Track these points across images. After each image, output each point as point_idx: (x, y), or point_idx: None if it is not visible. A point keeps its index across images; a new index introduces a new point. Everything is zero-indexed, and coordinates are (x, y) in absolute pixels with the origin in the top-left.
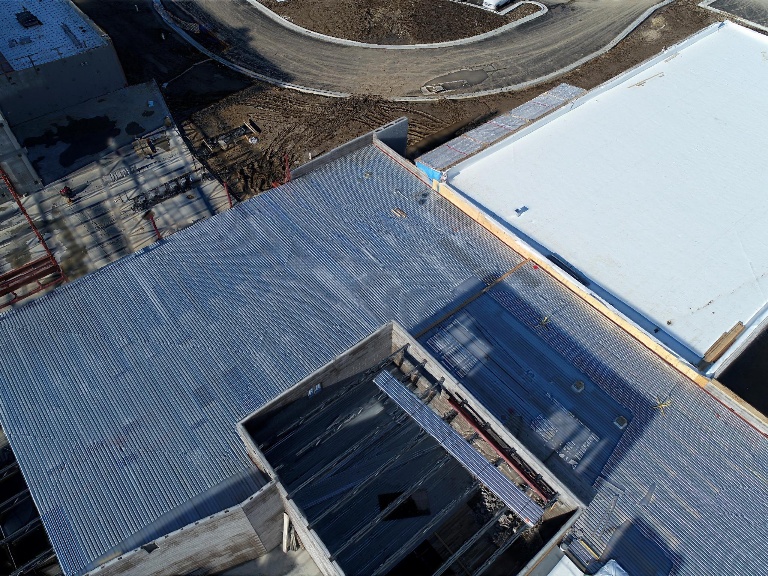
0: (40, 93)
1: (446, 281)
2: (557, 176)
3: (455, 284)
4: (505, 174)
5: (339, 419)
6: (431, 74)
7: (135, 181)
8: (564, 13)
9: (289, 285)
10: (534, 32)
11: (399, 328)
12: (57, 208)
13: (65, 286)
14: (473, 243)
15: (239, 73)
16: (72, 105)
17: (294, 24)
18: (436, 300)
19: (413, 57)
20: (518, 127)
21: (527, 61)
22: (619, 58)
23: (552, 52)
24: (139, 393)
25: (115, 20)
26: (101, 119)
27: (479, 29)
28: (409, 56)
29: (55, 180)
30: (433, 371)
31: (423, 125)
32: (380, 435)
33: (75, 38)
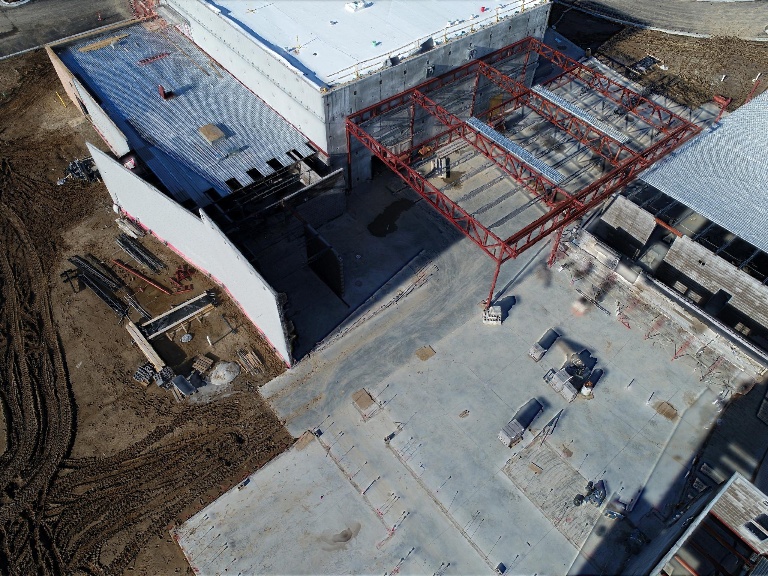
0: None
1: None
2: None
3: None
4: None
5: None
6: (764, 21)
7: (597, 95)
8: None
9: None
10: None
11: None
12: None
13: (678, 150)
14: None
15: (604, 19)
16: None
17: None
18: None
19: (738, 8)
20: None
21: None
22: None
23: None
24: None
25: None
26: None
27: None
28: (734, 7)
29: None
30: None
31: None
32: None
33: None
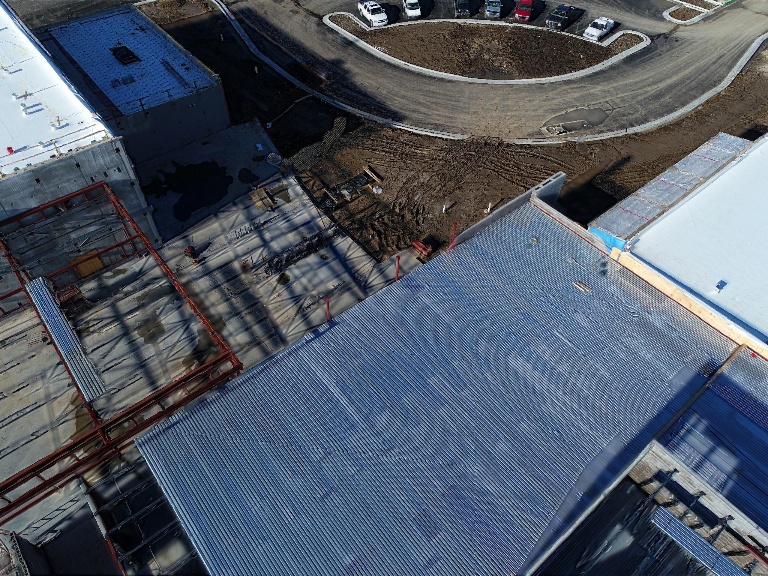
0: (146, 137)
1: (658, 372)
2: (746, 243)
3: (669, 376)
4: (689, 241)
5: (587, 553)
6: (547, 113)
7: (261, 238)
8: (669, 44)
9: (486, 378)
10: (643, 65)
11: (665, 452)
12: (182, 270)
13: (237, 380)
14: (673, 324)
15: (344, 111)
16: (175, 148)
17: (390, 56)
18: (654, 397)
19: (523, 93)
20: (693, 186)
21: (644, 98)
22: (742, 96)
23: (668, 88)
24: (353, 521)
25: (201, 51)
26: (209, 165)
27: (585, 62)
28: (519, 92)
29: (174, 237)
30: (713, 506)
31: (555, 172)
32: (640, 575)
33: (180, 77)
